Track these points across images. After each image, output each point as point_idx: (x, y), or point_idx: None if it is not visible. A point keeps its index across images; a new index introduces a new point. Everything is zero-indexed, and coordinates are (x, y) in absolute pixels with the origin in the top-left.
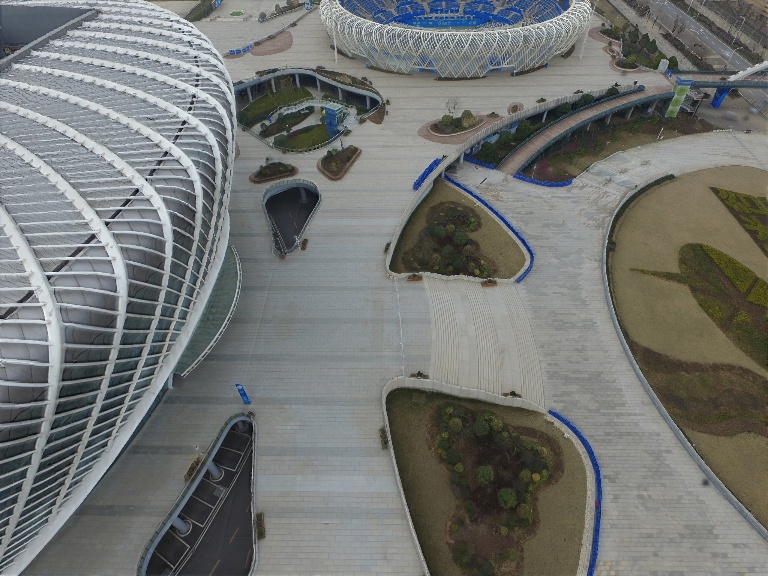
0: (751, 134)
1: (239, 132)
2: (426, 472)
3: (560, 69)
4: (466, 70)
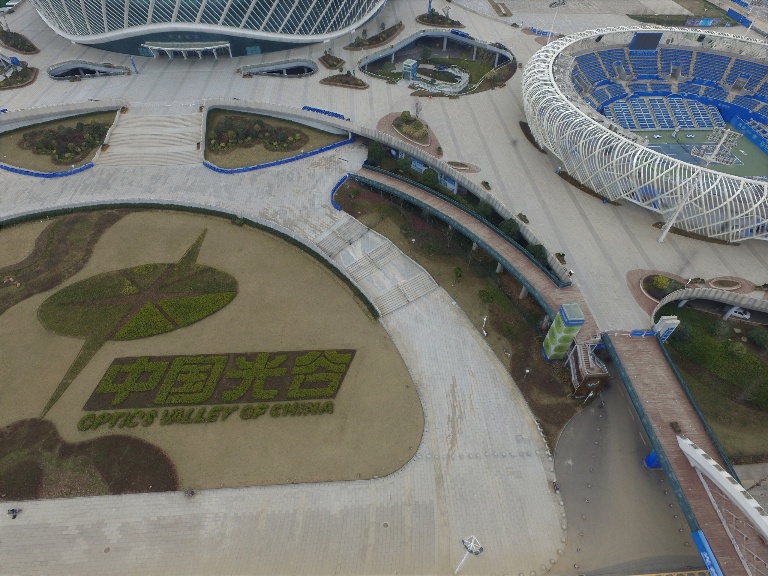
0: (551, 491)
1: None
2: None
3: (604, 214)
4: None
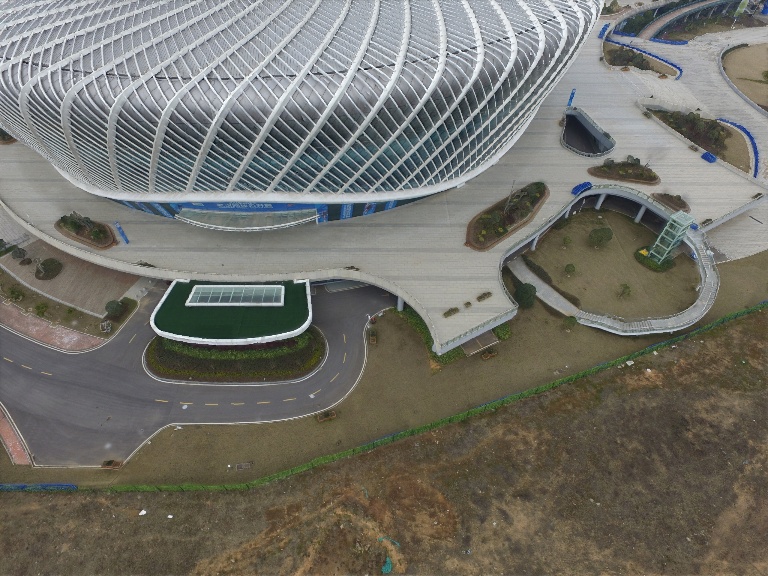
0: None
1: None
2: None
3: None
4: None
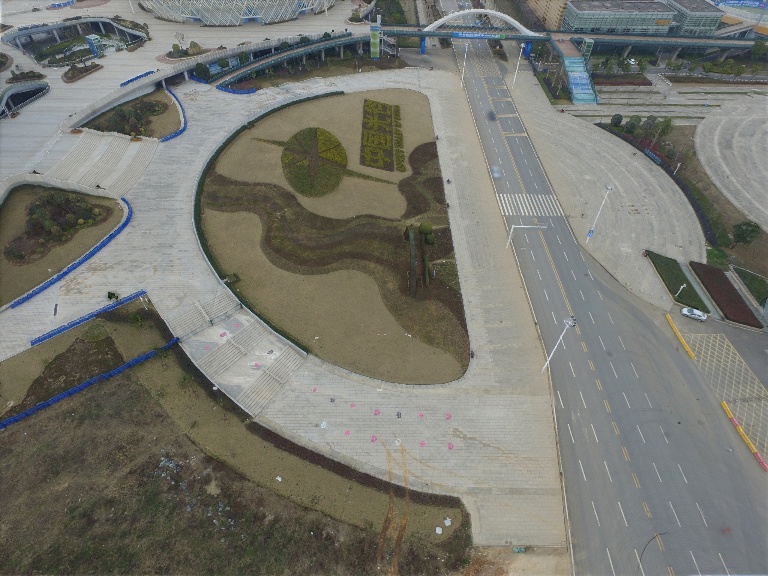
0: (433, 70)
1: (20, 55)
2: (15, 219)
3: (304, 22)
4: (222, 19)
